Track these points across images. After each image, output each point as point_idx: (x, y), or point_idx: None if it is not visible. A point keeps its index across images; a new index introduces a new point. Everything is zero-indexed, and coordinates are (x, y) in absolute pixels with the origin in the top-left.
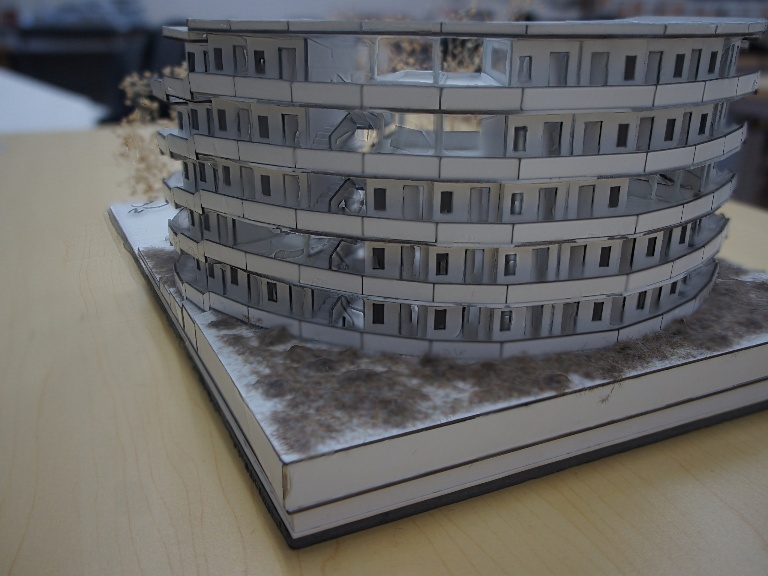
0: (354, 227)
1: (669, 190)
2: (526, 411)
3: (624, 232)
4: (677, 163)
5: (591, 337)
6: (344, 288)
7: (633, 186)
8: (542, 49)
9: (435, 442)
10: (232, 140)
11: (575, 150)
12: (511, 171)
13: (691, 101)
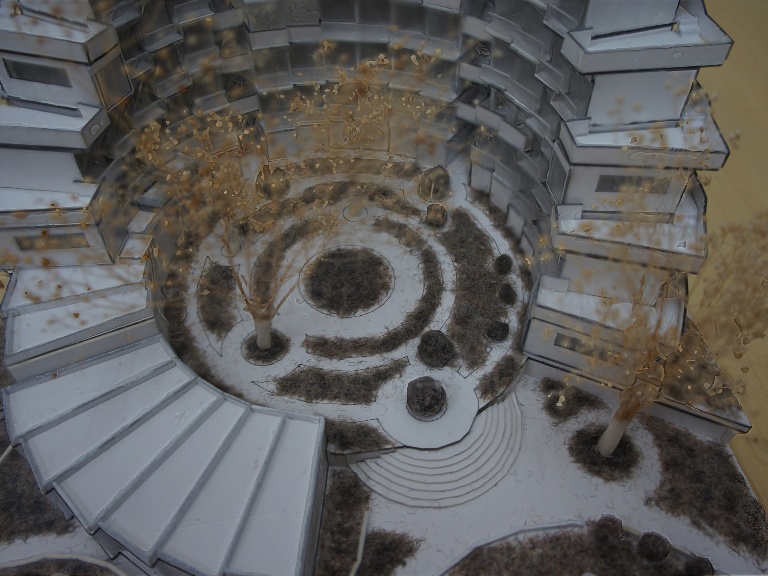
0: None
1: (237, 1)
2: None
3: None
4: None
5: None
6: None
7: None
8: None
9: None
10: None
11: None
12: None
13: None
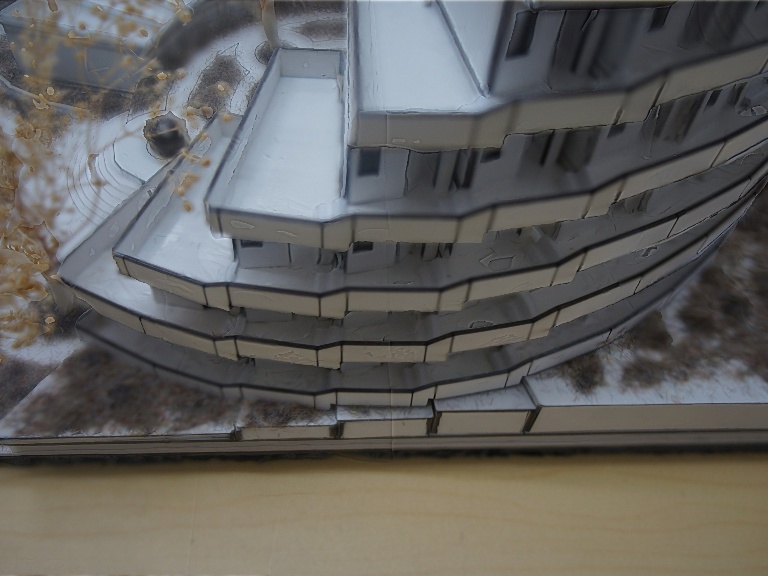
0: None
1: None
2: None
3: None
4: None
5: None
6: None
7: None
8: None
9: None
10: (719, 146)
11: None
12: None
13: None
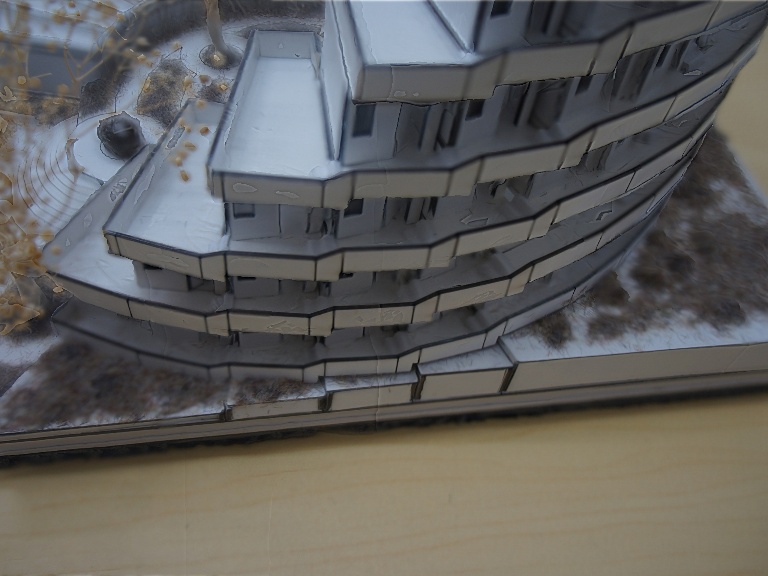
0: None
1: None
2: None
3: None
4: None
5: None
6: None
7: None
8: None
9: None
10: (671, 100)
11: None
12: None
13: None
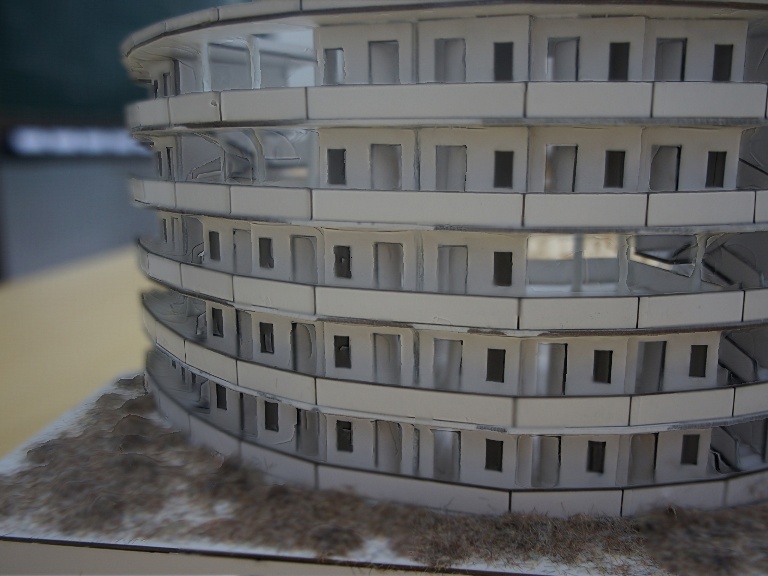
0: (176, 275)
1: (682, 284)
2: (254, 568)
3: (498, 324)
4: (606, 220)
5: (458, 491)
6: (177, 353)
7: (648, 278)
8: (355, 37)
9: (108, 570)
10: None
11: (424, 188)
12: (303, 207)
13: (622, 114)
